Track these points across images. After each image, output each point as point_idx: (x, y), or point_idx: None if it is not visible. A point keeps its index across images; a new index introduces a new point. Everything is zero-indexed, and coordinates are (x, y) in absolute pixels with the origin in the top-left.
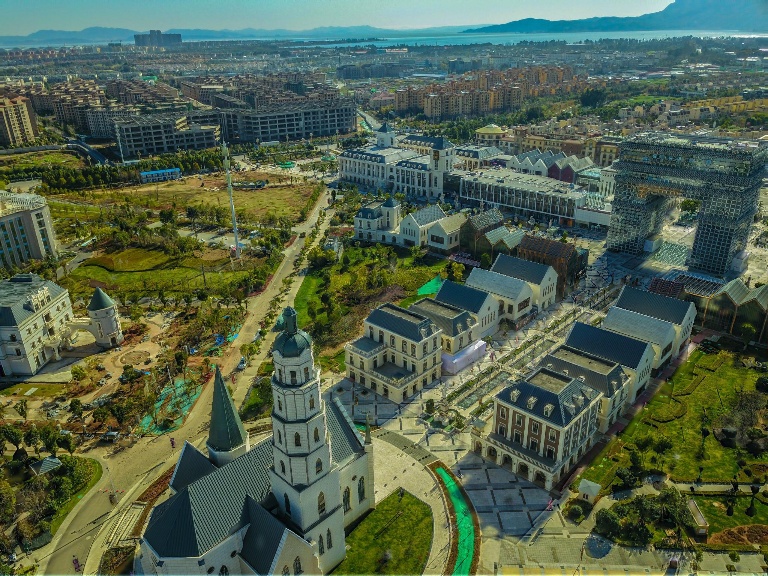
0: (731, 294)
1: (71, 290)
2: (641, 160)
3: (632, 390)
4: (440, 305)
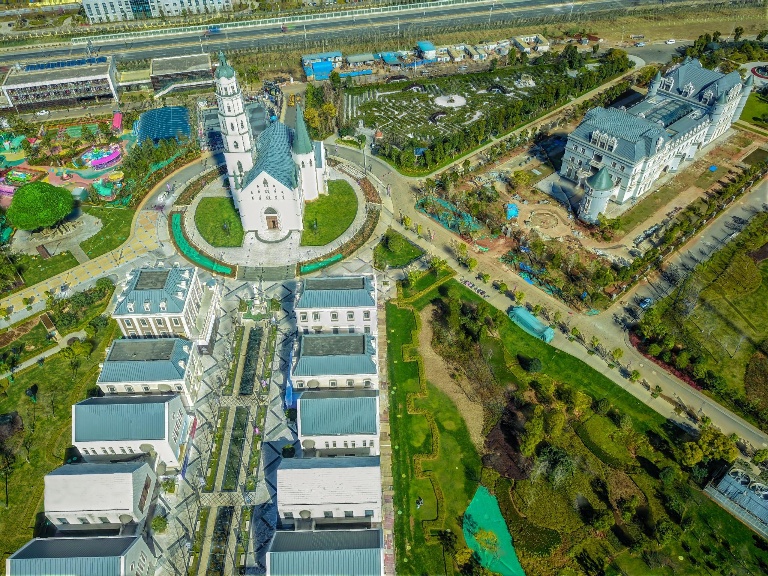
0: None
1: (763, 227)
2: None
3: None
4: (340, 354)
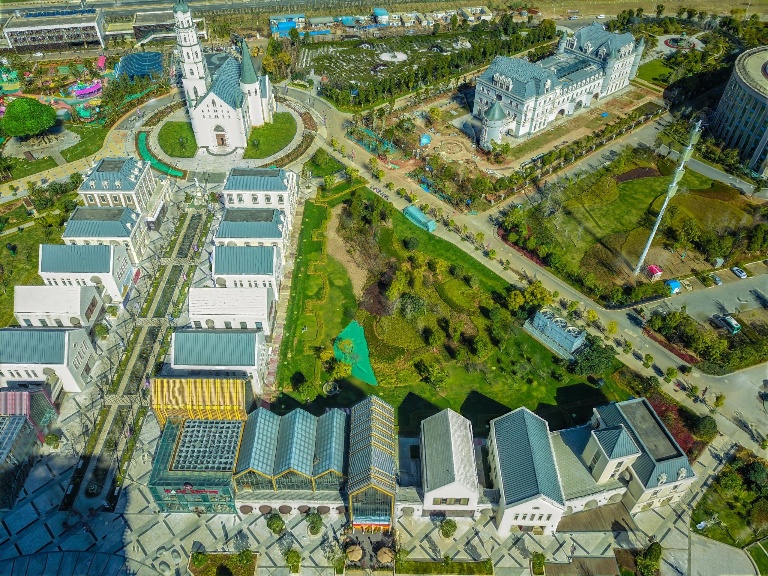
0: None
1: None
2: None
3: None
4: (253, 221)
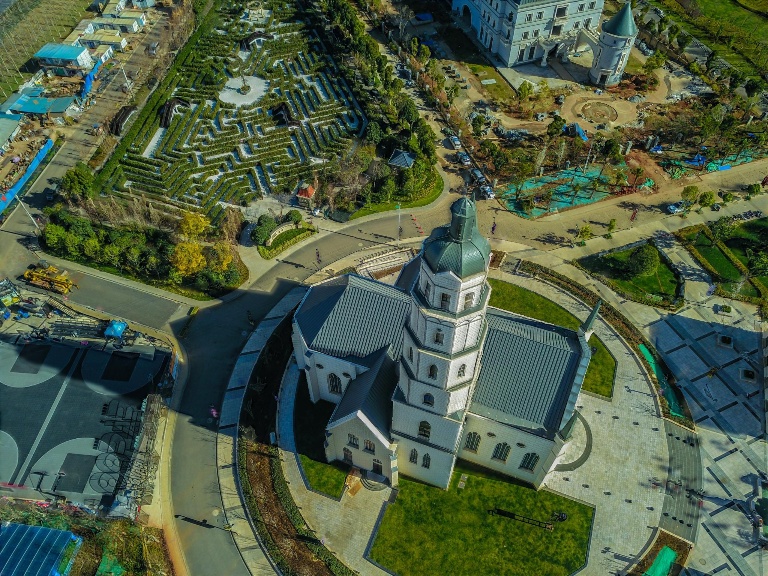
0: None
1: None
2: None
3: None
4: None
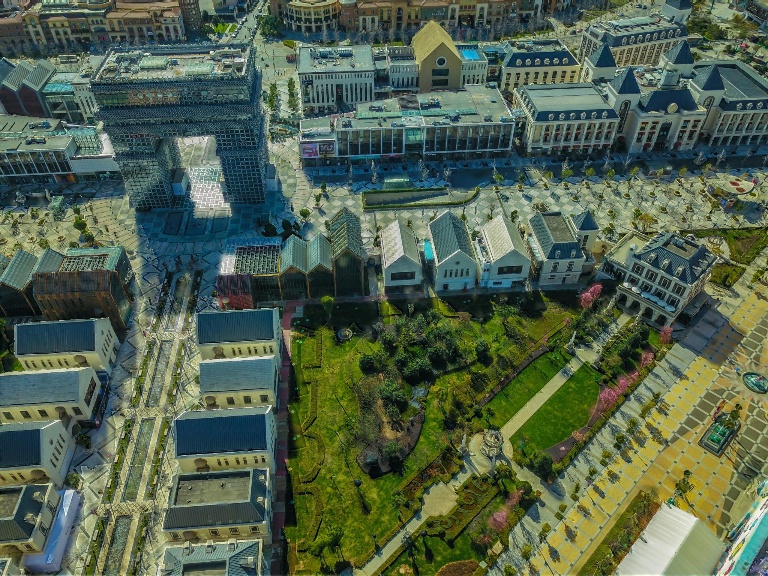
0: (296, 264)
1: None
2: (126, 103)
3: (271, 465)
4: None
